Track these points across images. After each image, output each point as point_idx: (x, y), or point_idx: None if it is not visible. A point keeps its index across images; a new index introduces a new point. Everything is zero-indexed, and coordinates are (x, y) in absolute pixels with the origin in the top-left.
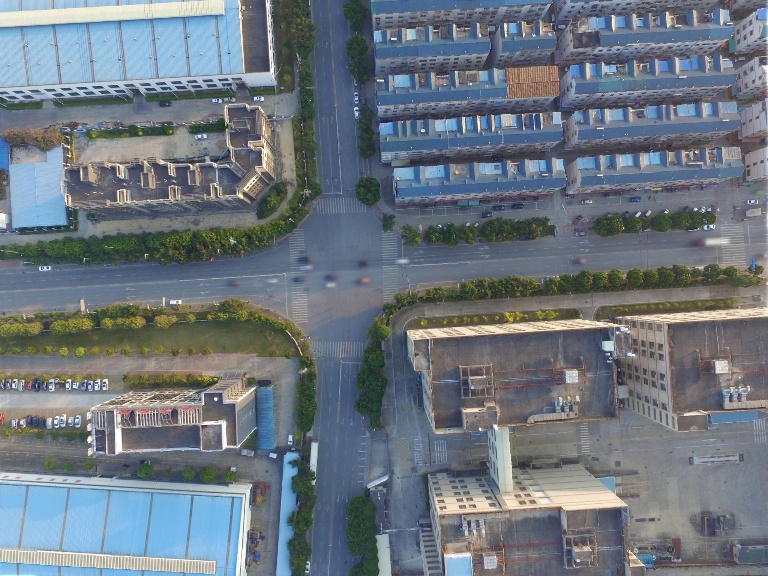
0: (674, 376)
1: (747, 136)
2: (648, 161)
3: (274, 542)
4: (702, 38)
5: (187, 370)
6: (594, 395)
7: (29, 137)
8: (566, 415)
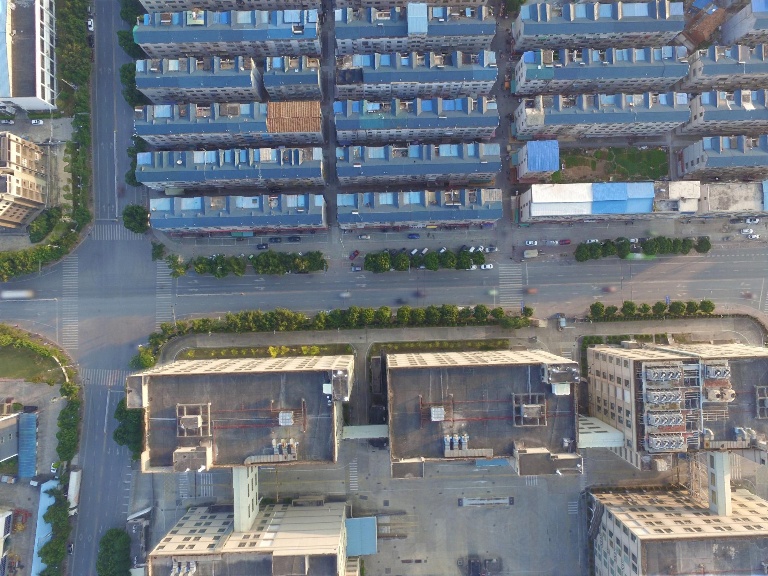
0: (396, 421)
1: (521, 177)
2: (408, 200)
3: None
4: (466, 79)
5: None
6: (315, 438)
7: None
8: (284, 457)
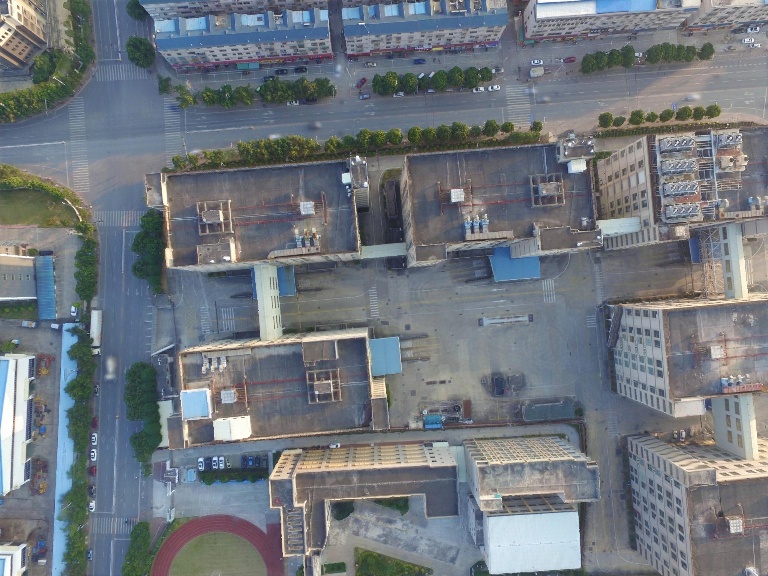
0: (416, 209)
1: None
2: (413, 11)
3: None
4: None
5: None
6: (337, 230)
7: None
8: (307, 250)
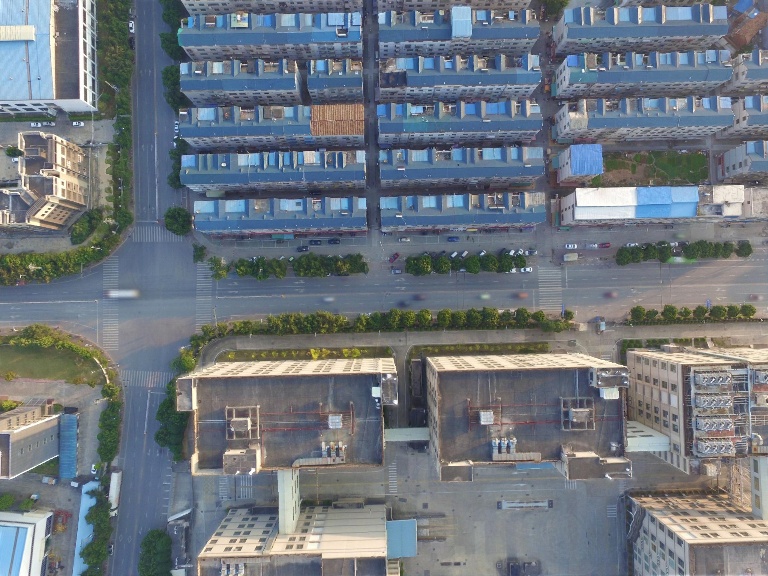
0: (444, 425)
1: (562, 181)
2: (451, 203)
3: None
4: (510, 82)
5: None
6: (363, 441)
7: None
8: (332, 460)
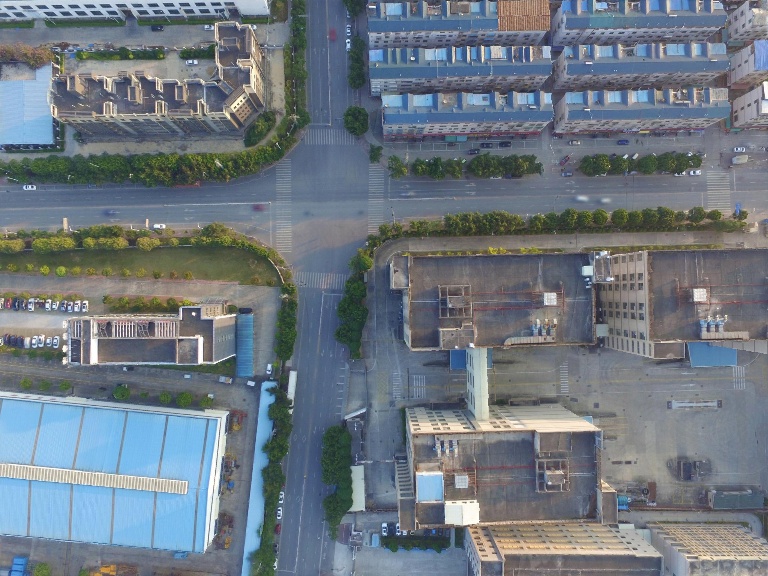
0: (652, 304)
1: (736, 82)
2: (636, 99)
3: (249, 471)
4: None
5: (168, 295)
6: (572, 320)
7: (19, 53)
8: (543, 339)
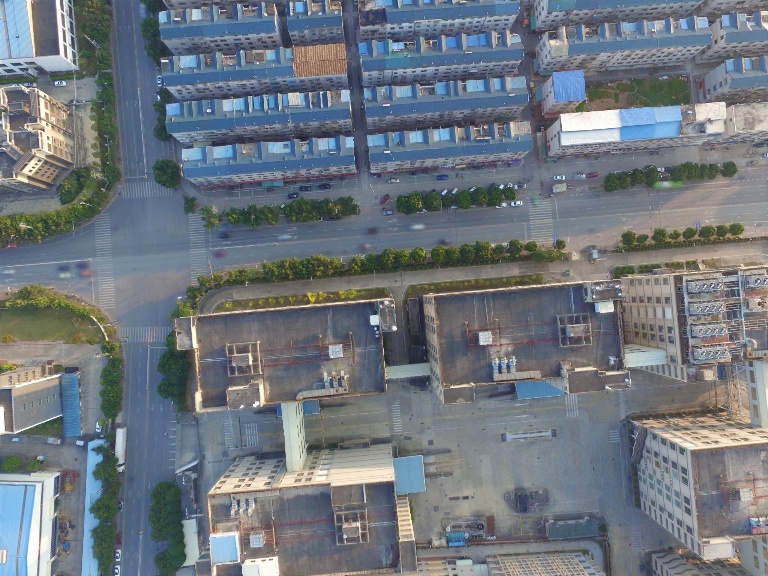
0: (444, 349)
1: (547, 112)
2: (438, 137)
3: None
4: (489, 14)
5: None
6: (364, 370)
7: None
8: (335, 391)
